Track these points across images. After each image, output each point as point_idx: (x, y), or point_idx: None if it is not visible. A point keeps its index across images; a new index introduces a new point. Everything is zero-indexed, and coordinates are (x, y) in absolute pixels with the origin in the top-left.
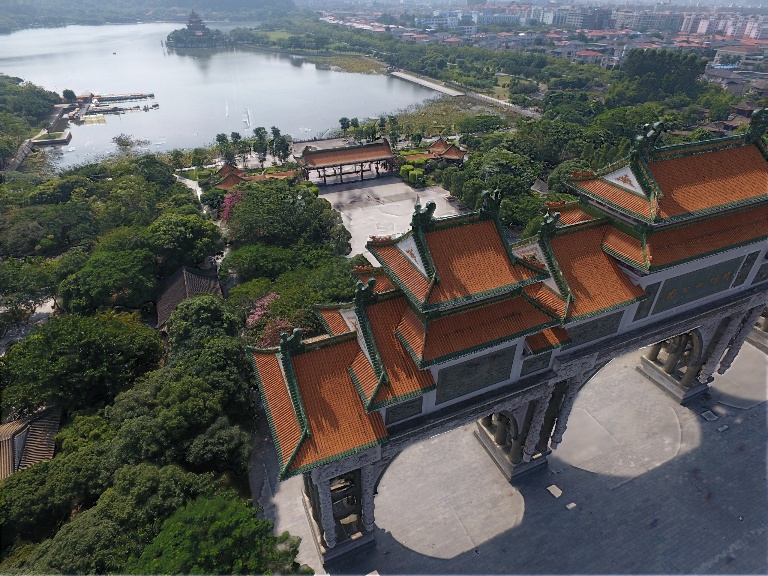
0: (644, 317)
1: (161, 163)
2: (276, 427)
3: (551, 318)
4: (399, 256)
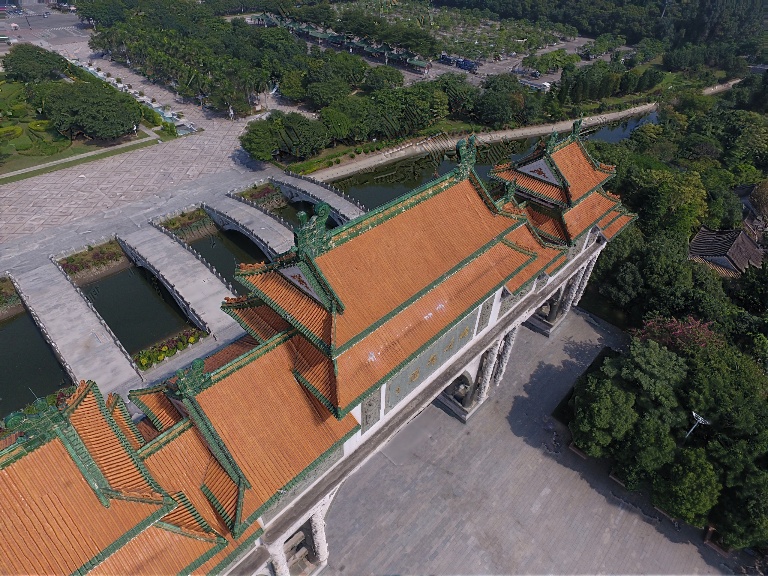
0: None
1: None
2: None
3: None
4: None
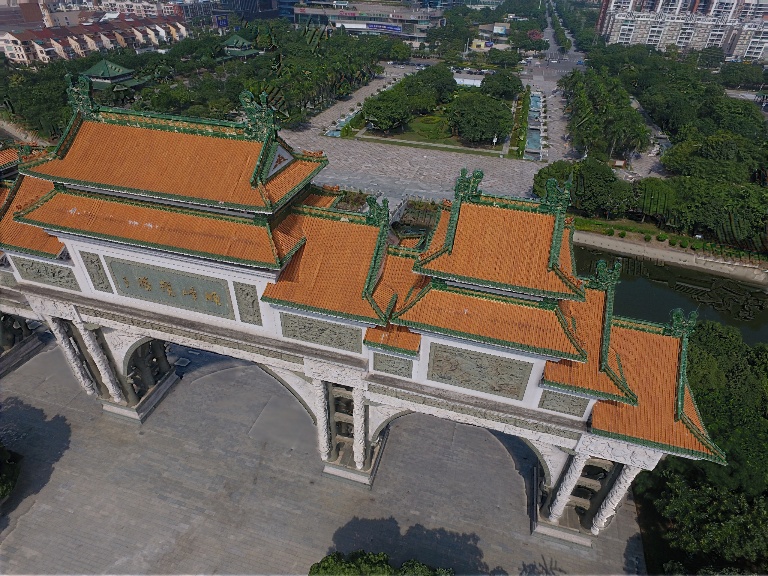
0: None
1: None
2: None
3: None
4: None
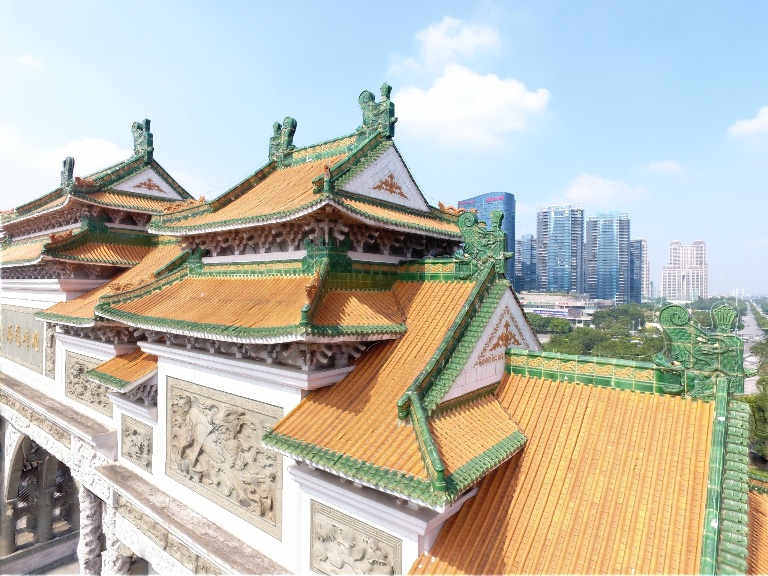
0: None
1: None
2: None
3: None
4: None
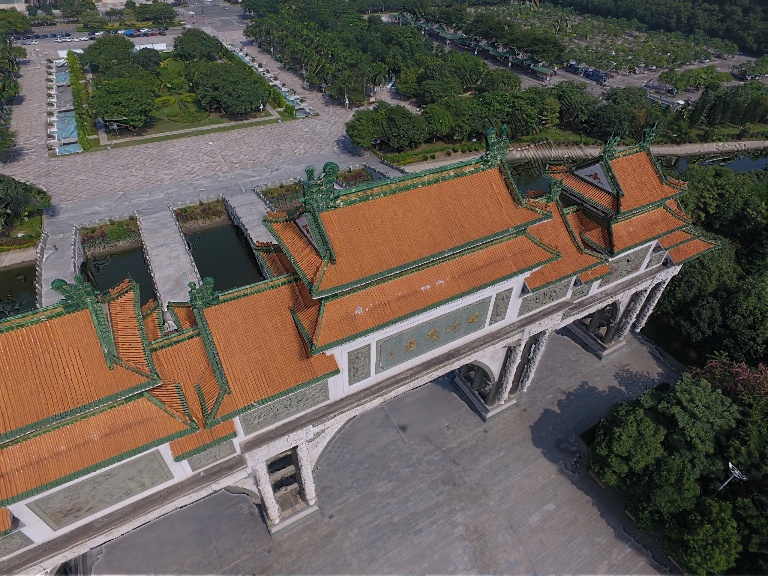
0: None
1: None
2: None
3: None
4: None
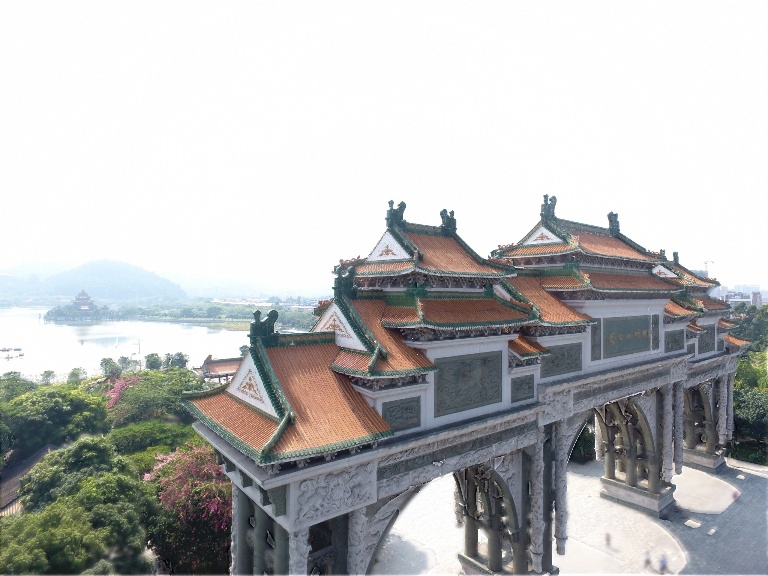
0: (598, 359)
1: (26, 381)
2: (238, 436)
3: (528, 315)
4: (371, 266)
